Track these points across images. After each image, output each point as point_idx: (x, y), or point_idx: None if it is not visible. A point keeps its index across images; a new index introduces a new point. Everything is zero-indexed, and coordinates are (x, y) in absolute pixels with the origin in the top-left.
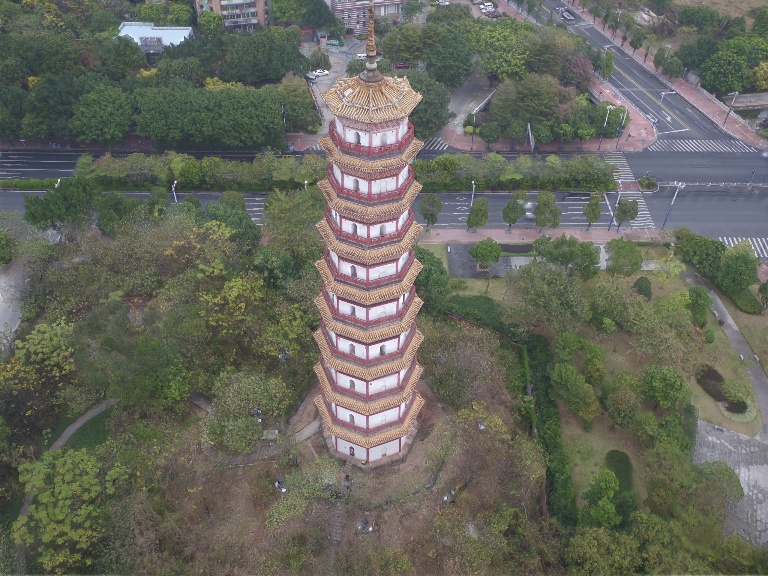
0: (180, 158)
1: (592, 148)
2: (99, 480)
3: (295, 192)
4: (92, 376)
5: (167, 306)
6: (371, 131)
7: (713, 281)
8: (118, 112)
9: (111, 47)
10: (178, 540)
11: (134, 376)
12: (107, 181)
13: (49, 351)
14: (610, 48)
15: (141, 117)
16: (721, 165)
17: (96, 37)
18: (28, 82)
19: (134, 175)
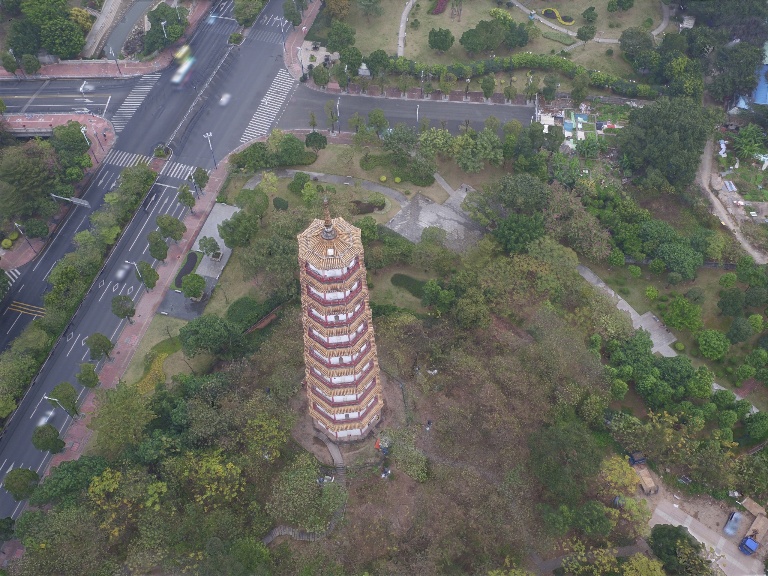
0: None
1: None
2: None
3: (97, 398)
4: None
5: (163, 552)
6: None
7: (280, 165)
8: None
9: None
10: (424, 538)
11: None
12: None
13: None
14: None
15: None
16: (165, 100)
17: None
18: None
19: None
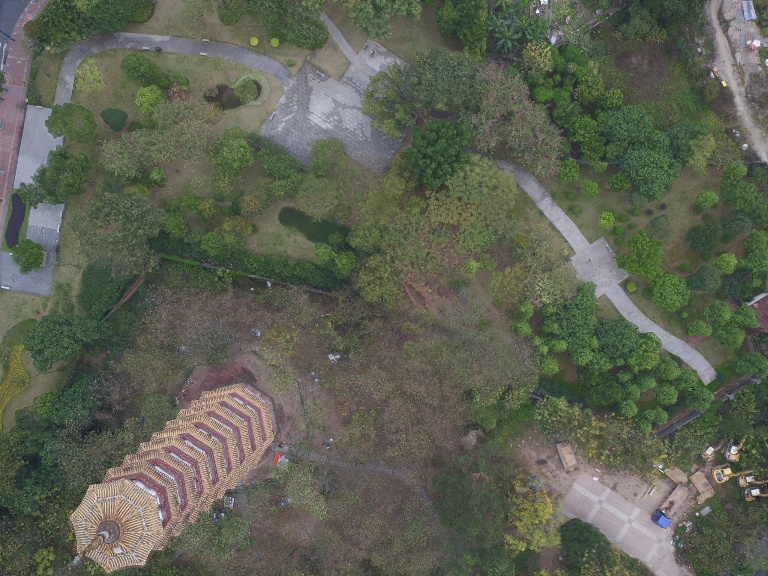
0: None
1: None
2: None
3: None
4: None
5: None
6: None
7: None
8: None
9: None
10: None
11: None
12: None
13: None
14: None
15: None
16: None
17: None
18: None
19: None
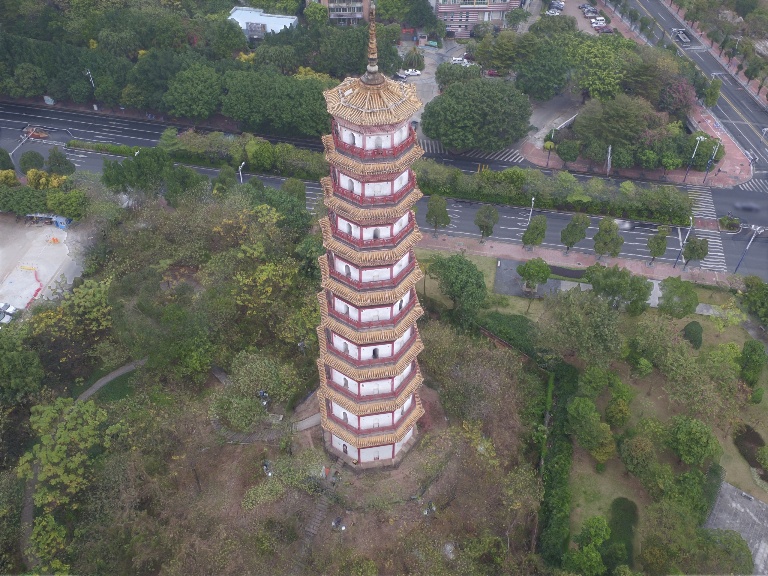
0: (255, 141)
1: (677, 179)
2: (99, 432)
3: None
4: (121, 335)
5: (208, 280)
6: (364, 133)
7: None
8: (207, 91)
9: (216, 29)
10: (157, 502)
11: (159, 341)
12: (187, 155)
13: (90, 306)
14: (722, 76)
15: (227, 98)
16: None
17: (206, 18)
18: (138, 55)
19: (212, 152)
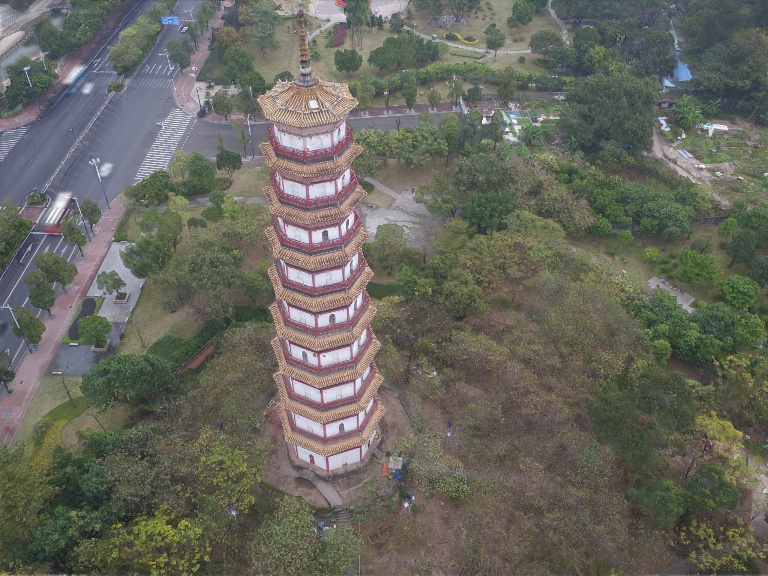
0: None
1: None
2: None
3: None
4: None
5: None
6: None
7: (188, 194)
8: None
9: None
10: (492, 570)
11: None
12: None
13: None
14: None
15: None
16: (36, 150)
17: None
18: None
19: None
